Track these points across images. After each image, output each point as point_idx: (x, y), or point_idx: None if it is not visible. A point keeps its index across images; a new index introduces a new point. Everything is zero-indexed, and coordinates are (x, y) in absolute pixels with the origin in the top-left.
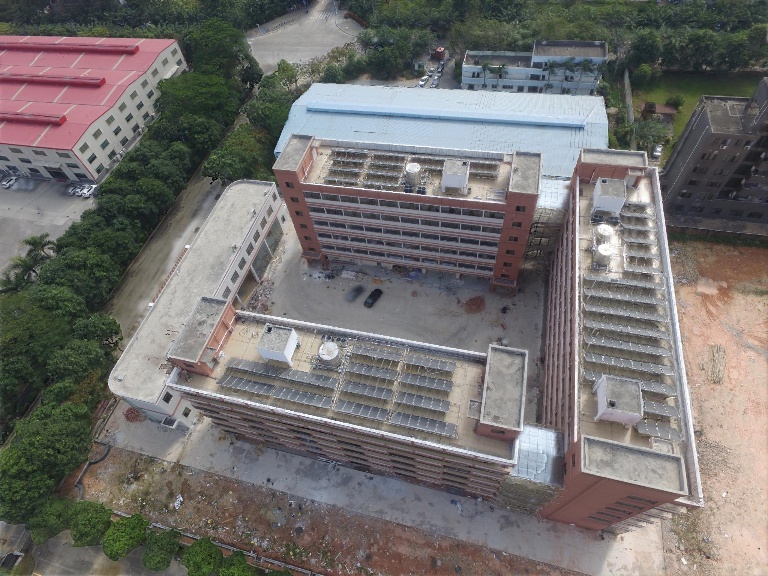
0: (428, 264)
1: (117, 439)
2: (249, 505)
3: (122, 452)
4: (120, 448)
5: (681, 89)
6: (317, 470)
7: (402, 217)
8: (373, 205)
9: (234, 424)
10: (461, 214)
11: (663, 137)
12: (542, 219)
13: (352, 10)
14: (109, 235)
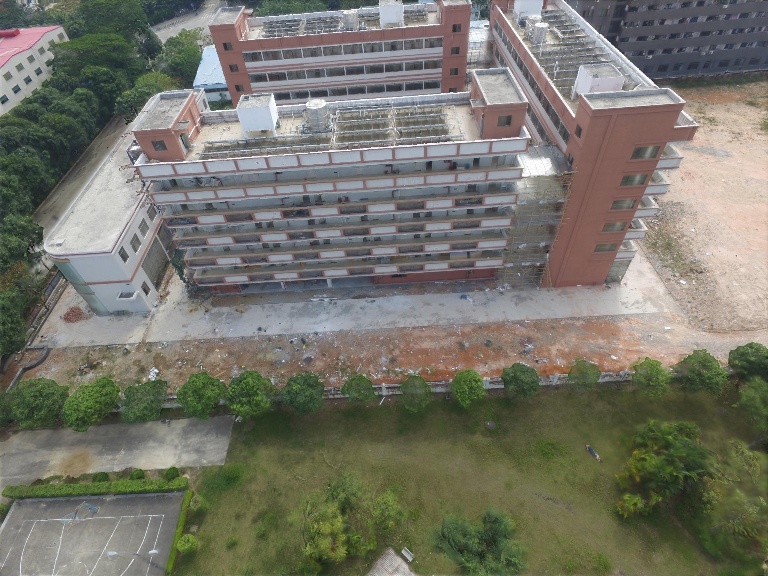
0: None
1: (57, 340)
2: (243, 355)
3: (67, 350)
4: (63, 347)
5: None
6: (312, 309)
7: (347, 68)
8: (317, 57)
9: (212, 256)
10: (403, 49)
11: None
12: (473, 58)
13: None
14: (14, 158)
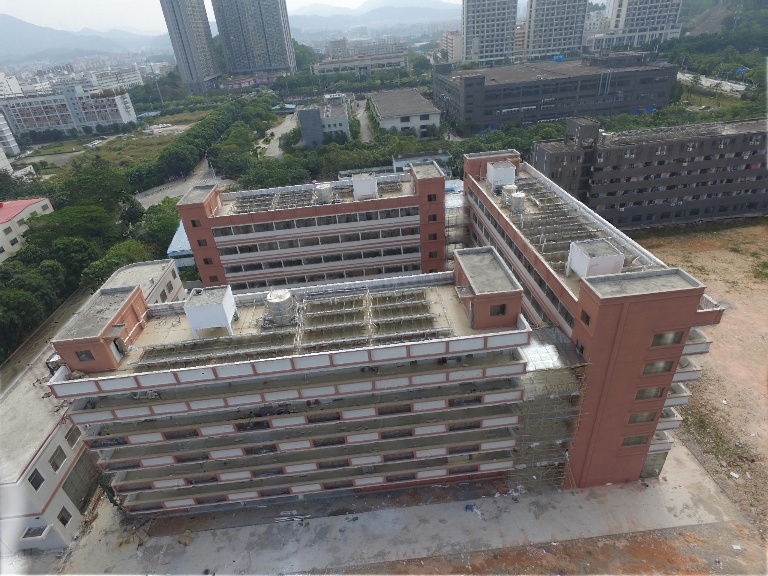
0: None
1: None
2: None
3: None
4: None
5: None
6: (278, 534)
7: (321, 237)
8: (289, 229)
9: (148, 478)
10: (379, 218)
11: None
12: (451, 222)
13: (228, 174)
14: None
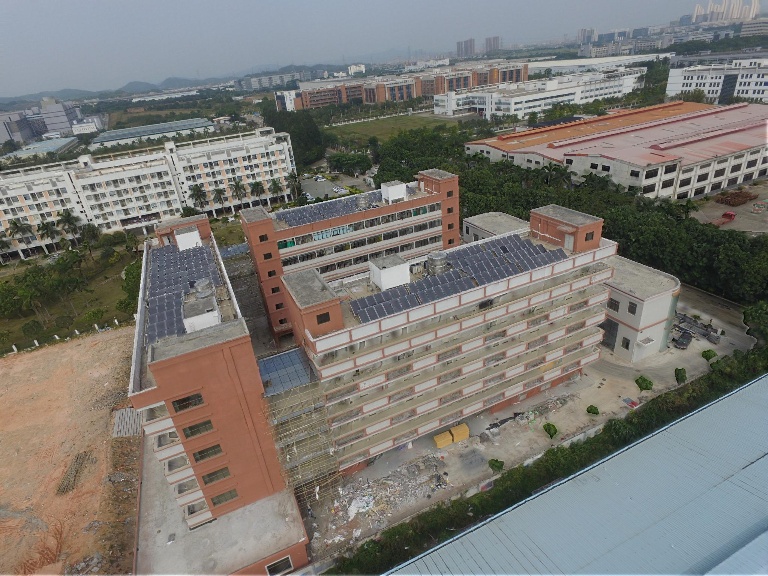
0: None
1: None
2: None
3: None
4: None
5: None
6: None
7: None
8: None
9: None
10: None
11: None
12: None
13: None
14: (677, 236)
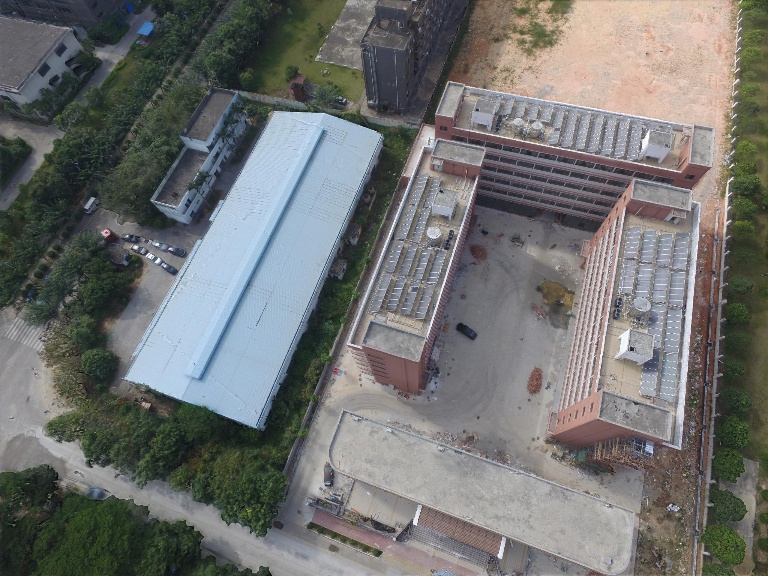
0: None
1: None
2: None
3: None
4: None
5: (268, 66)
6: None
7: None
8: None
9: None
10: None
11: None
12: None
13: None
14: None
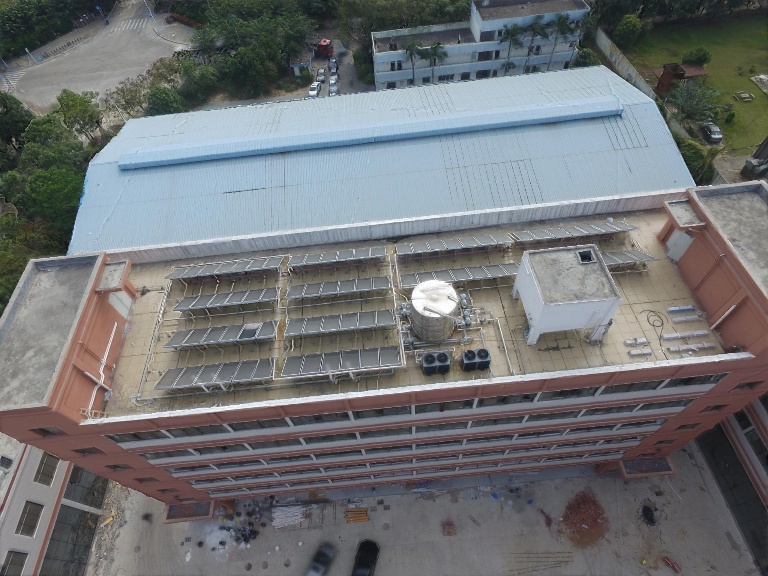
0: (473, 470)
1: None
2: None
3: None
4: None
5: (679, 44)
6: None
7: (419, 425)
8: (333, 422)
9: None
10: (596, 394)
11: (727, 109)
12: None
13: (176, 11)
14: None
